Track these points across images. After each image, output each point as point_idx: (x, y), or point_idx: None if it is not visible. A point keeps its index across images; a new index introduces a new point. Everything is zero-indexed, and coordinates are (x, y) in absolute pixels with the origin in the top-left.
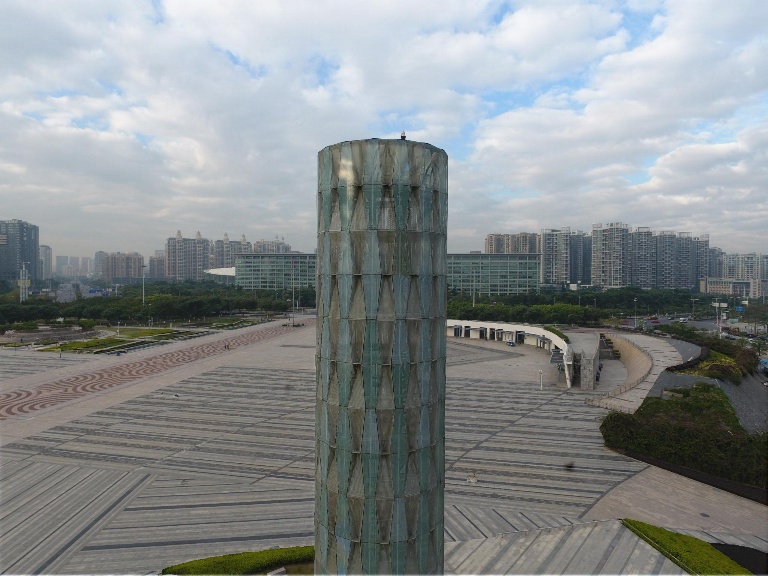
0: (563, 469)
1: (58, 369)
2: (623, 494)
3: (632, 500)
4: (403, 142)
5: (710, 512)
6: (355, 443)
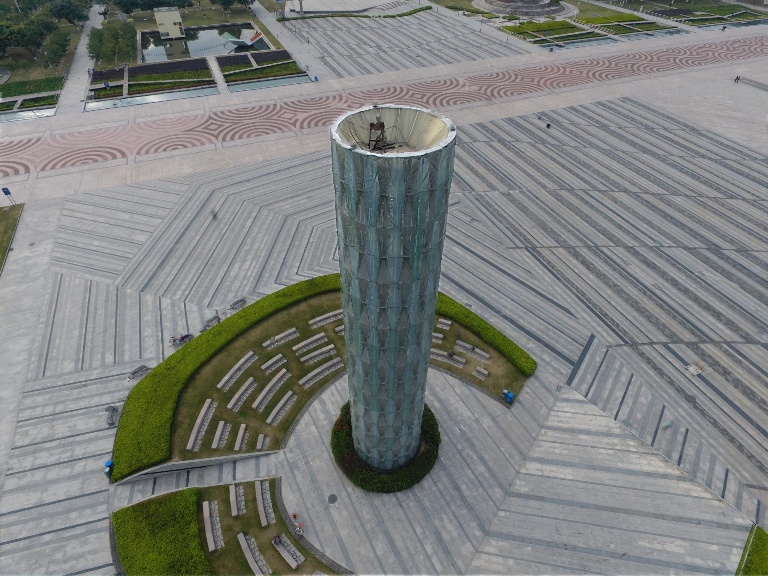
0: None
1: (494, 59)
2: None
3: None
4: (349, 152)
5: None
6: None
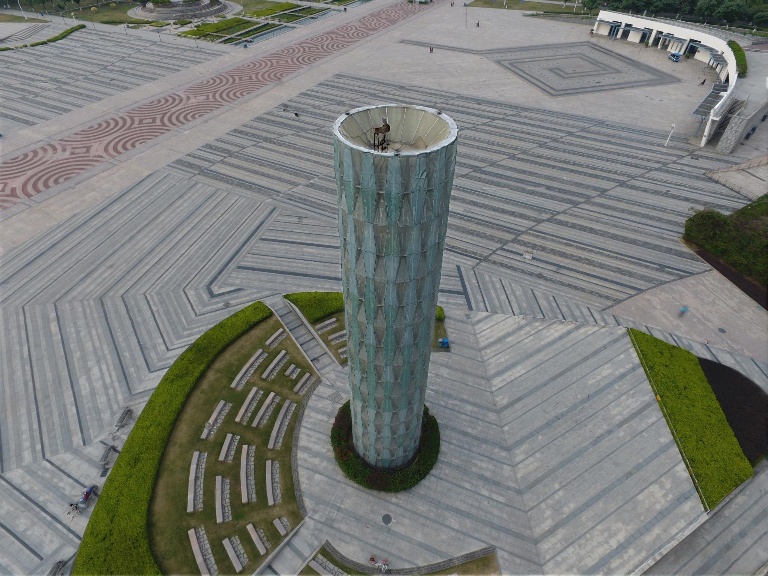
0: (620, 258)
1: (198, 66)
2: (660, 295)
3: (663, 303)
4: (396, 158)
5: (730, 329)
6: (362, 335)
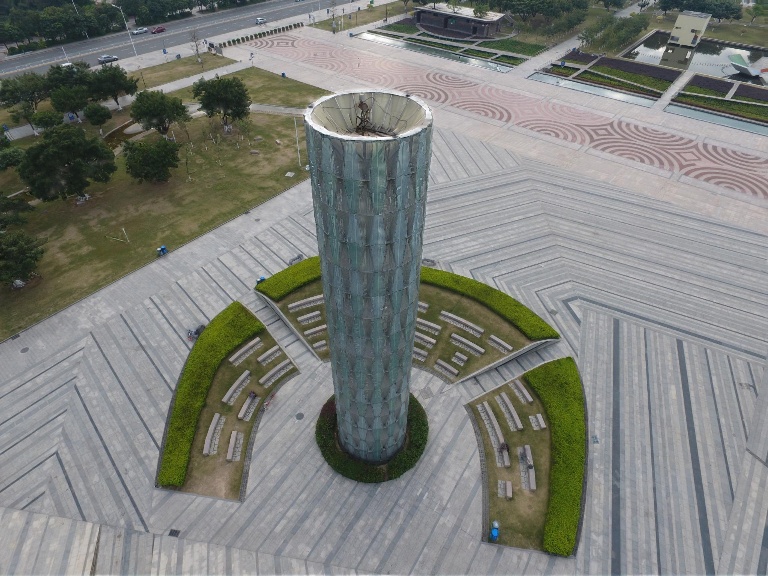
0: None
1: None
2: None
3: None
4: None
5: None
6: None
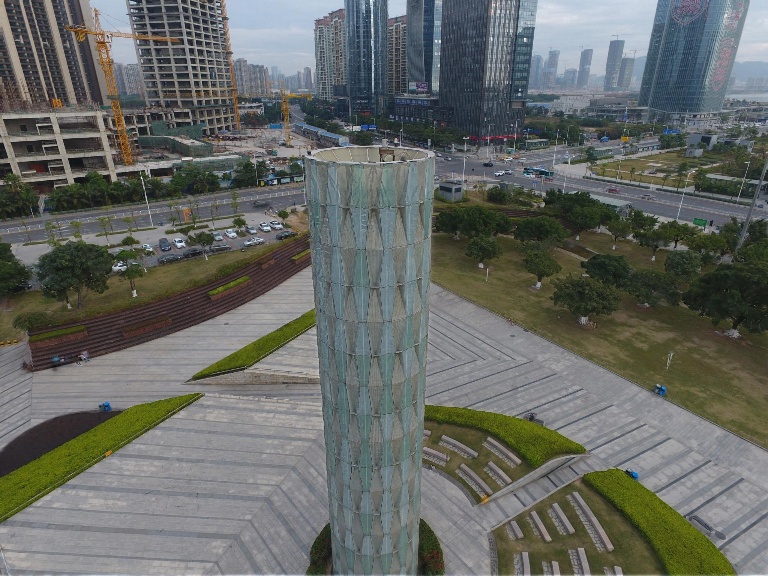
0: None
1: None
2: None
3: None
4: None
5: None
6: None
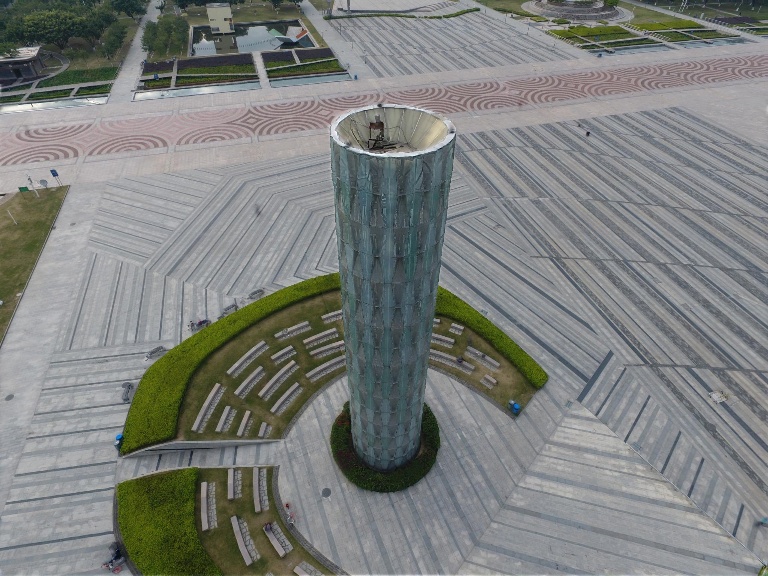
0: None
1: (538, 63)
2: None
3: None
4: (344, 149)
5: None
6: None
